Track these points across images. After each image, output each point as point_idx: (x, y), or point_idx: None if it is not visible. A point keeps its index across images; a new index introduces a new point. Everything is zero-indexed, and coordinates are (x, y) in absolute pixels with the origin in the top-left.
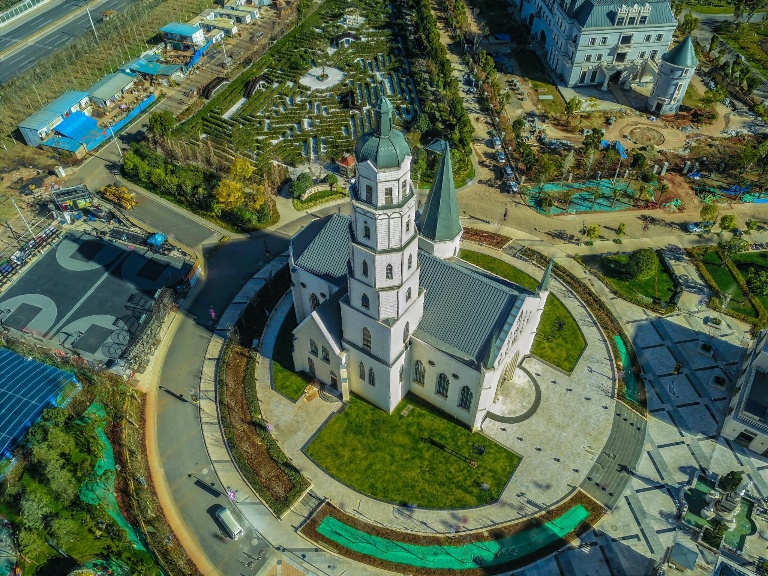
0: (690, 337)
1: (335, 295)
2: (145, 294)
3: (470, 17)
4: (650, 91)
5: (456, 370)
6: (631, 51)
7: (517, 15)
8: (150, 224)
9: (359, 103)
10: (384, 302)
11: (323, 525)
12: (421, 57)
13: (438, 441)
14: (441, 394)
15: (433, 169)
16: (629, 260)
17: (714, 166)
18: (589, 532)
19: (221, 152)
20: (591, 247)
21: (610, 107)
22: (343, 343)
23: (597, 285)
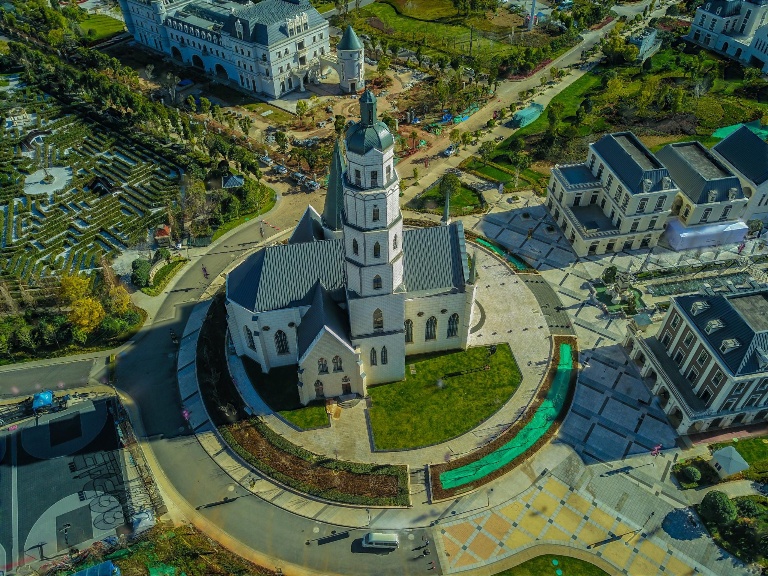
0: (511, 216)
1: (324, 307)
2: (84, 453)
3: (138, 77)
4: (335, 79)
5: (444, 305)
6: (308, 53)
7: (177, 62)
8: (9, 396)
9: (113, 185)
10: (395, 272)
11: (444, 482)
12: (127, 125)
13: (453, 372)
14: (429, 339)
15: (241, 202)
16: (441, 189)
17: (423, 109)
18: (579, 355)
19: (14, 292)
20: (404, 196)
21: (320, 101)
22: (352, 341)
23: (433, 217)
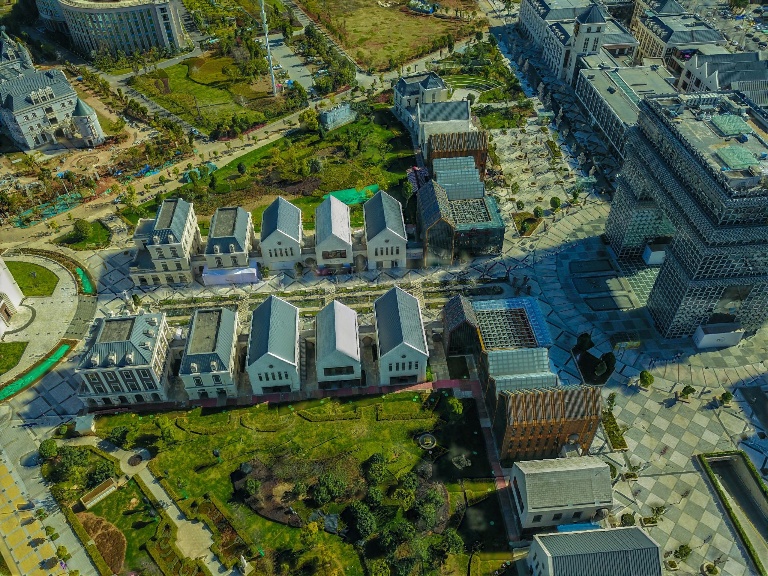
0: (119, 252)
1: None
2: None
3: None
4: None
5: None
6: (57, 116)
7: None
8: None
9: None
10: None
11: None
12: None
13: None
14: None
15: None
16: None
17: (125, 164)
18: (71, 353)
19: None
20: (59, 233)
21: (61, 152)
22: None
23: (65, 250)
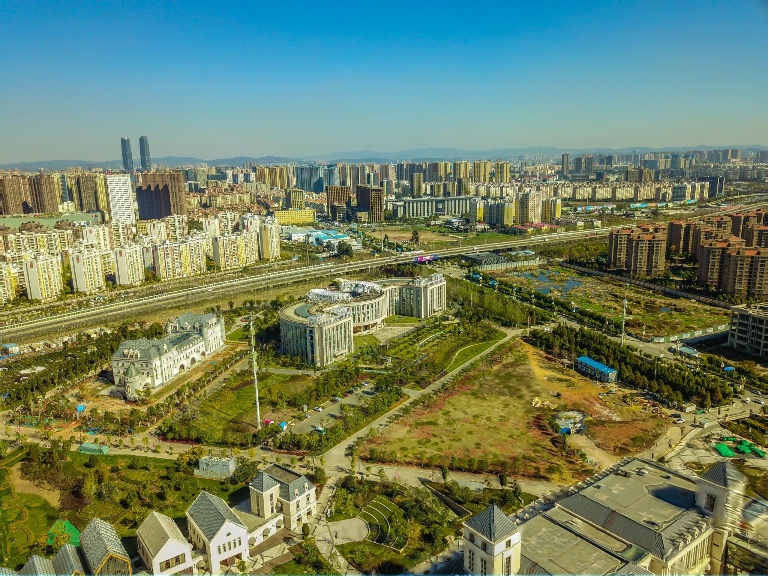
0: None
1: None
2: None
3: None
4: None
5: None
6: None
7: None
8: None
9: None
10: None
11: None
12: None
13: None
14: None
15: None
16: None
17: None
18: None
19: None
20: None
21: None
22: None
23: None
